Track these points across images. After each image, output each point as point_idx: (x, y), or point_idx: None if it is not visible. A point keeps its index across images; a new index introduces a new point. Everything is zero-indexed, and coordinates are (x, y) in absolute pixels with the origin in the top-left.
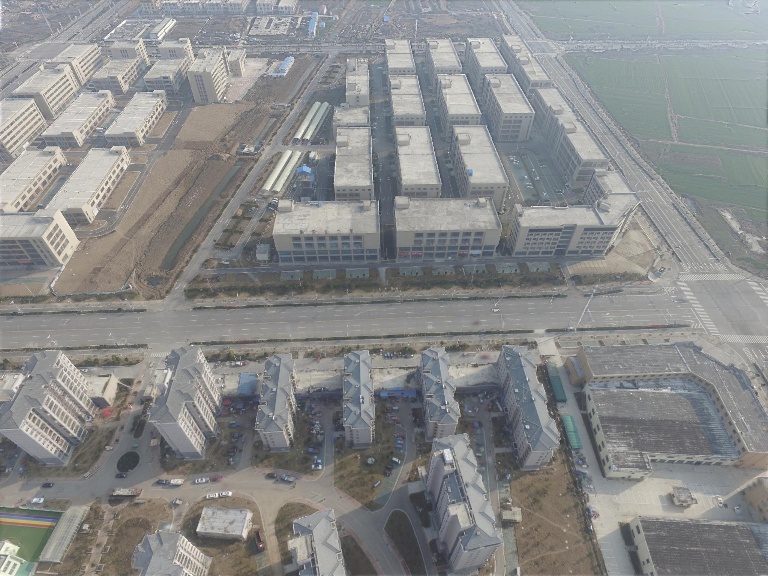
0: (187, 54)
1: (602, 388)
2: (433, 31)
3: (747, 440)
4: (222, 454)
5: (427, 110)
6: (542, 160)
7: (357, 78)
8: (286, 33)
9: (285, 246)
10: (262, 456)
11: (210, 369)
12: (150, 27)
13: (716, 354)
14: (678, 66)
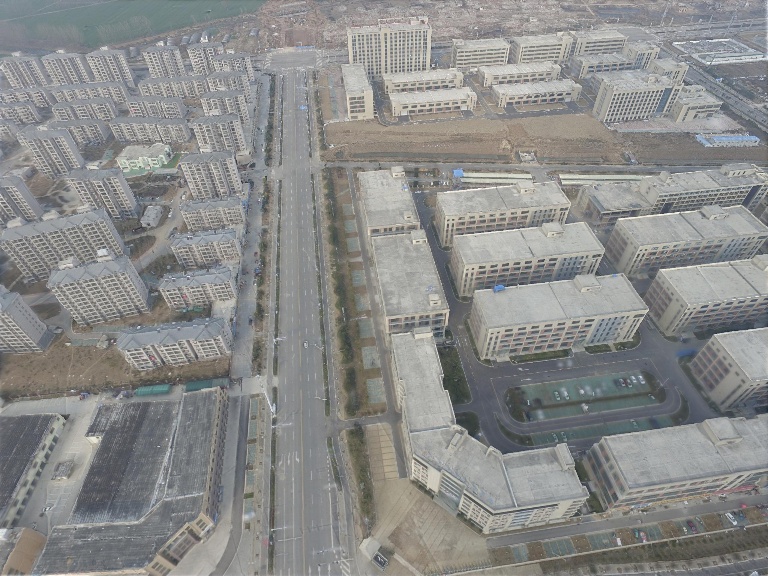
0: None
1: None
2: None
3: (66, 532)
4: None
5: None
6: (654, 423)
7: (702, 180)
8: None
9: None
10: None
11: None
12: None
13: None
14: None
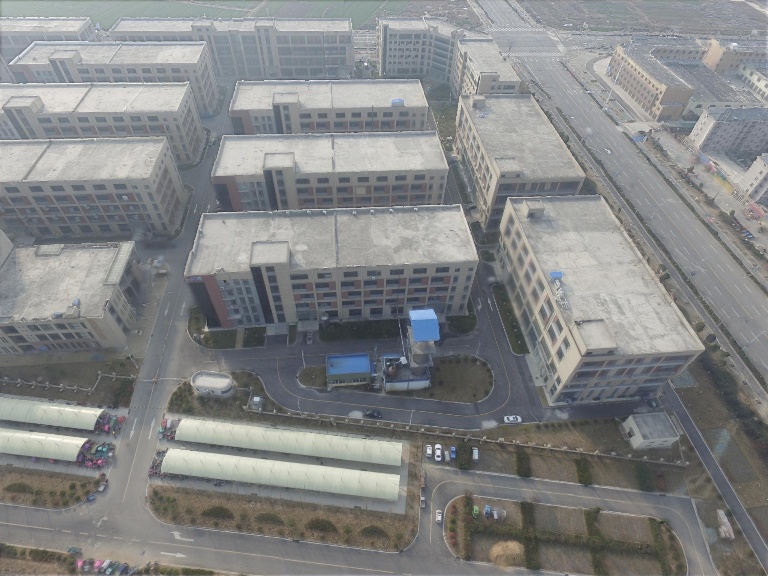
0: None
1: None
2: None
3: None
4: None
5: None
6: None
7: None
8: None
9: None
10: None
11: None
12: None
13: (586, 58)
14: None
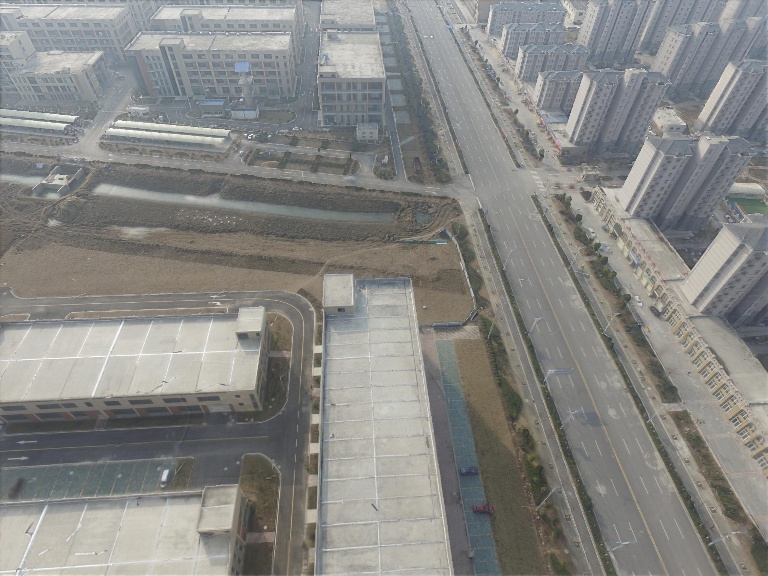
0: None
1: None
2: None
3: None
4: None
5: None
6: None
7: None
8: None
9: None
10: None
11: None
12: None
13: None
14: None
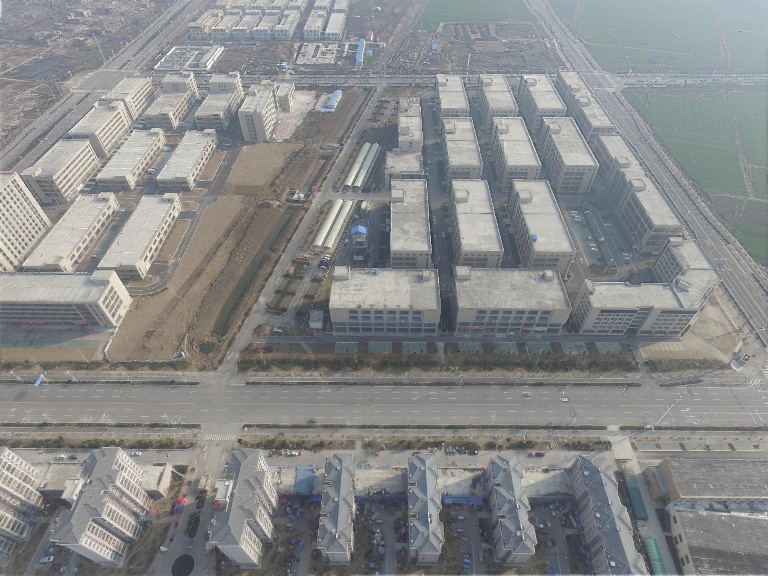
0: (236, 88)
1: (689, 509)
2: (483, 61)
3: None
4: (279, 563)
5: (481, 154)
6: (606, 217)
7: (410, 120)
8: (333, 62)
9: (341, 318)
10: (321, 568)
11: (267, 465)
12: (199, 55)
13: None
14: (748, 105)
